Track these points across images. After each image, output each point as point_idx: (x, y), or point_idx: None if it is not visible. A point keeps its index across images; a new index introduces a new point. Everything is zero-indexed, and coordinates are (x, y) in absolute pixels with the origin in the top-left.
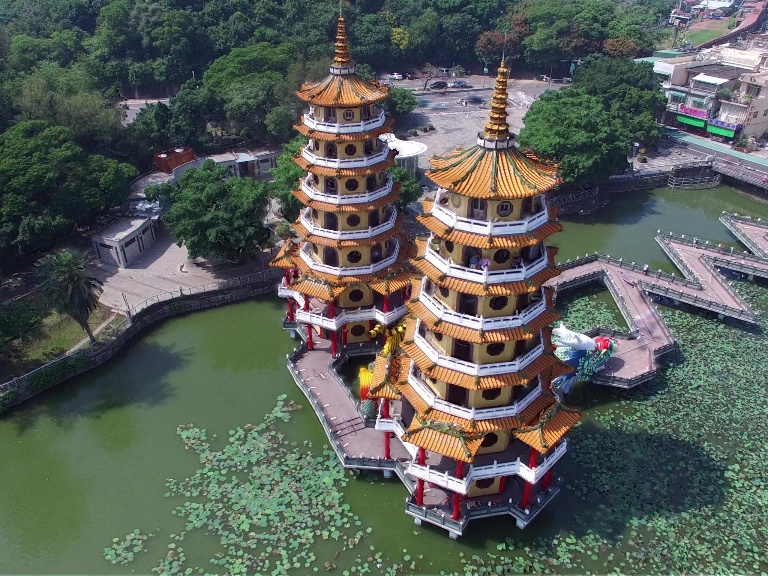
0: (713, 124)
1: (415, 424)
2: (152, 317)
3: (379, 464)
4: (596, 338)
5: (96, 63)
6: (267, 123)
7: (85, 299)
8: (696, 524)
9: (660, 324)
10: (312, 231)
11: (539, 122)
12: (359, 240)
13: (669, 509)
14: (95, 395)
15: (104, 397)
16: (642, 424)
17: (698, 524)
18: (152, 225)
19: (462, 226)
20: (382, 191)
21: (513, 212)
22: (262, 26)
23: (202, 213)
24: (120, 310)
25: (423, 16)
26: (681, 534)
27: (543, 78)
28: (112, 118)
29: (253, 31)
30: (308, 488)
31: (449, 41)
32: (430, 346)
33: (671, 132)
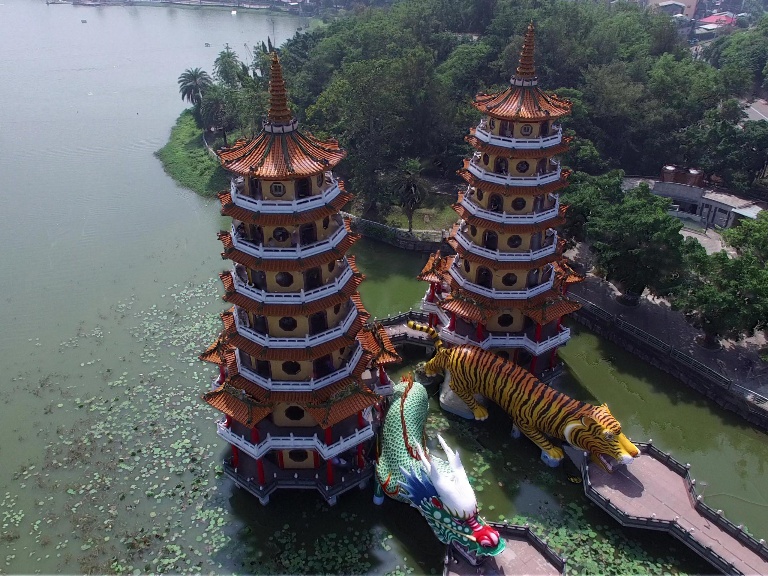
0: None
1: None
2: None
3: None
4: (551, 567)
5: (748, 73)
6: None
7: None
8: None
9: None
10: None
11: None
12: (462, 247)
13: None
14: (372, 255)
15: (370, 259)
16: None
17: None
18: None
19: None
20: (496, 216)
21: None
22: None
23: None
24: None
25: None
26: None
27: None
28: (652, 115)
29: None
30: None
31: None
32: None
33: None
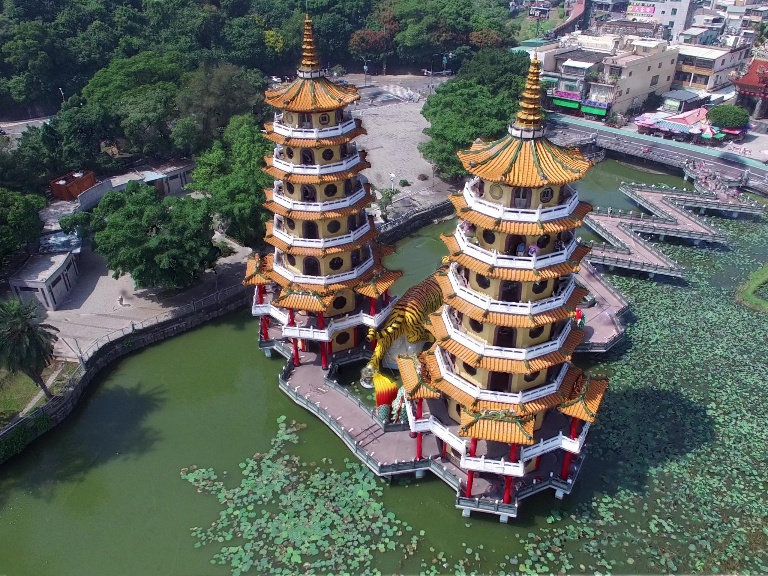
0: (586, 104)
1: (466, 418)
2: (104, 359)
3: (414, 466)
4: None
5: None
6: (173, 137)
7: (42, 350)
8: (702, 461)
9: (609, 289)
10: (292, 242)
11: (450, 114)
12: (343, 246)
13: (676, 453)
14: (68, 456)
15: (80, 456)
16: (625, 382)
17: (704, 461)
18: (74, 259)
19: (510, 216)
20: (359, 194)
21: (553, 197)
22: (126, 35)
23: (144, 239)
24: (67, 357)
25: (294, 17)
26: (694, 473)
27: (424, 72)
28: None
29: (117, 41)
30: (346, 505)
31: (322, 41)
32: (472, 339)
33: (550, 115)
